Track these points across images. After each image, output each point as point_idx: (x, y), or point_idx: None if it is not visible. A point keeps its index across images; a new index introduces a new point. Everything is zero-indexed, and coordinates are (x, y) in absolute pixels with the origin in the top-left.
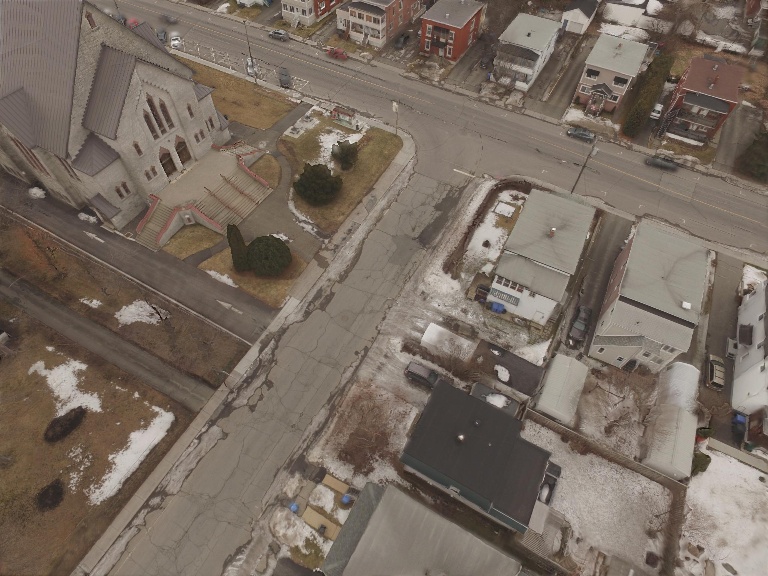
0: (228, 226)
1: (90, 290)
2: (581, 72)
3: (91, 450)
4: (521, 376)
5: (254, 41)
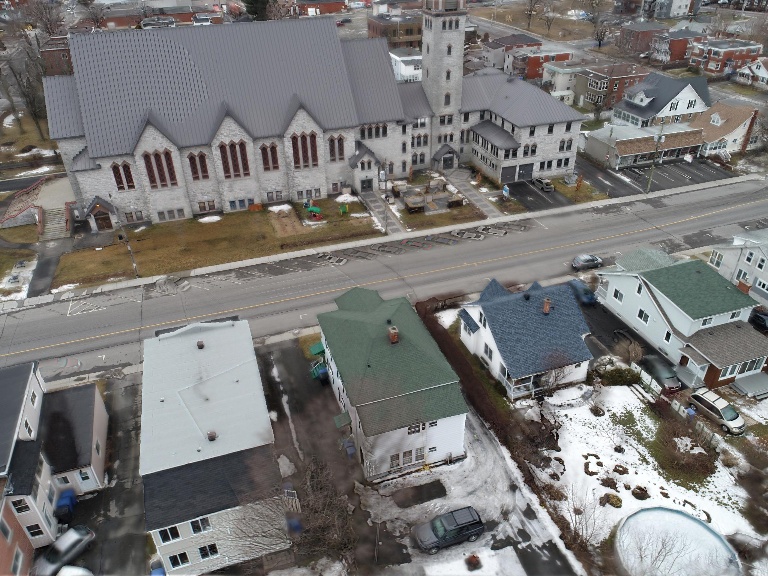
0: None
1: None
2: None
3: None
4: None
5: None
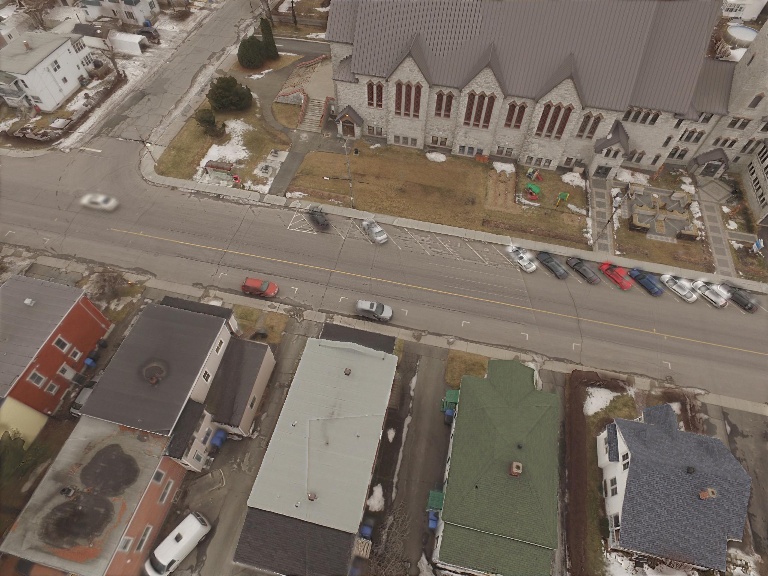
0: (266, 19)
1: None
2: None
3: (309, 0)
4: (87, 25)
5: (409, 292)
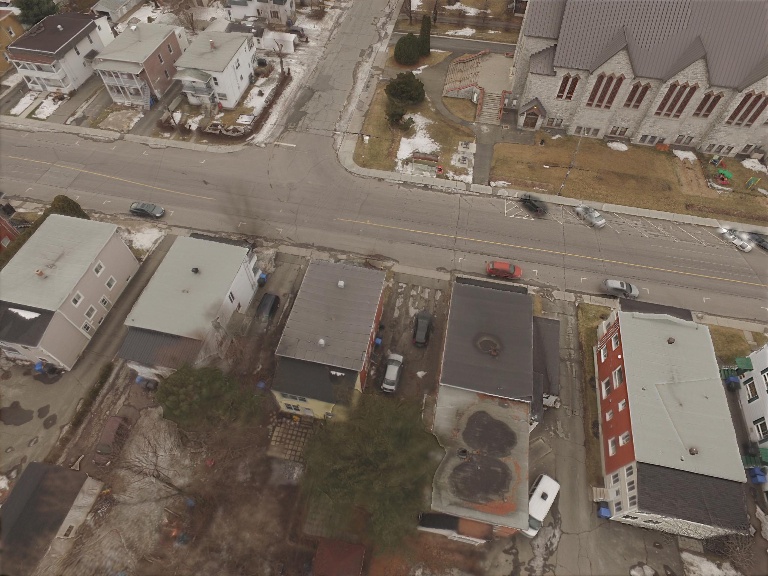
0: None
1: (501, 35)
2: (105, 333)
3: None
4: None
5: (643, 272)
